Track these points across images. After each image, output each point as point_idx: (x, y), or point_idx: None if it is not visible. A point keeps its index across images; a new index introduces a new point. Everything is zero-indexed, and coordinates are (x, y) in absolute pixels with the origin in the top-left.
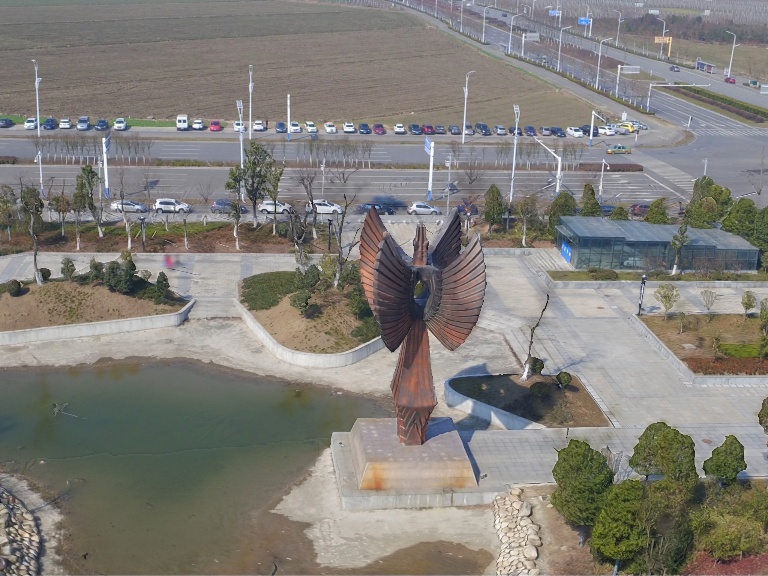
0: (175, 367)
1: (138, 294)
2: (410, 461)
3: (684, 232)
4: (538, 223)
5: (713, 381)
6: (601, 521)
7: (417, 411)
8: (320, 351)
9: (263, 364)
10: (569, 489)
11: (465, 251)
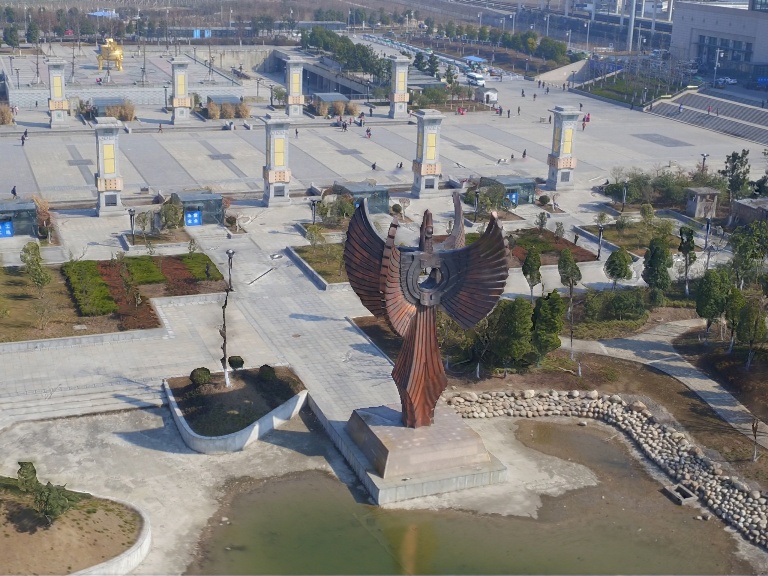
0: None
1: None
2: None
3: None
4: None
5: None
6: None
7: None
8: (133, 524)
9: None
10: None
11: None
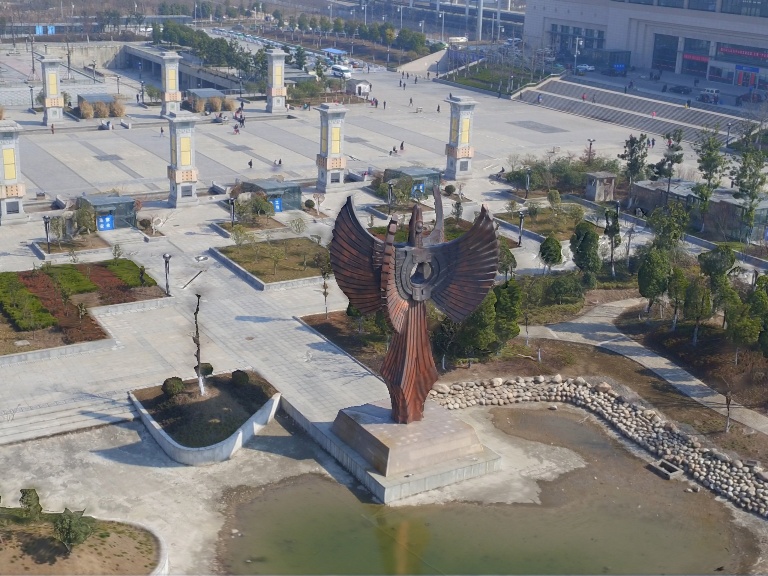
0: None
1: None
2: None
3: None
4: None
5: None
6: None
7: None
8: (148, 545)
9: None
10: None
11: None
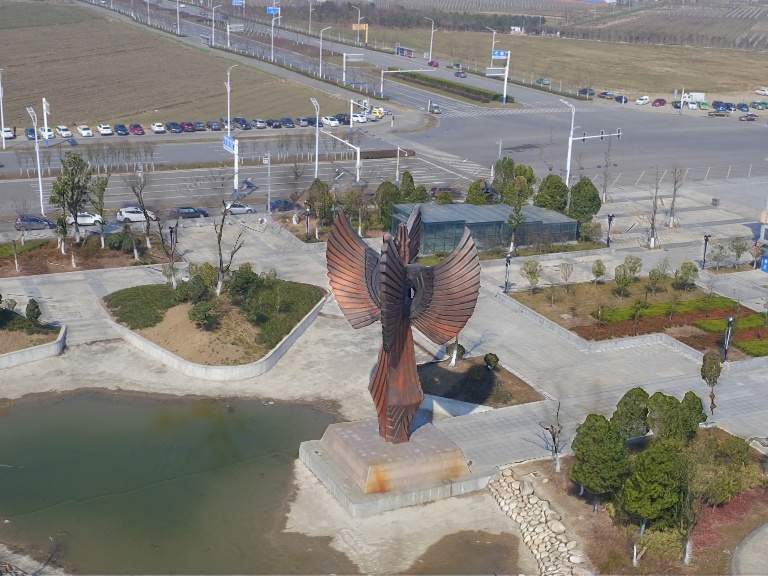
0: (83, 399)
1: (8, 326)
2: (408, 459)
3: (519, 211)
4: (365, 213)
5: (605, 346)
6: (631, 486)
7: (406, 409)
8: (233, 363)
9: (176, 384)
10: (593, 461)
11: (458, 246)
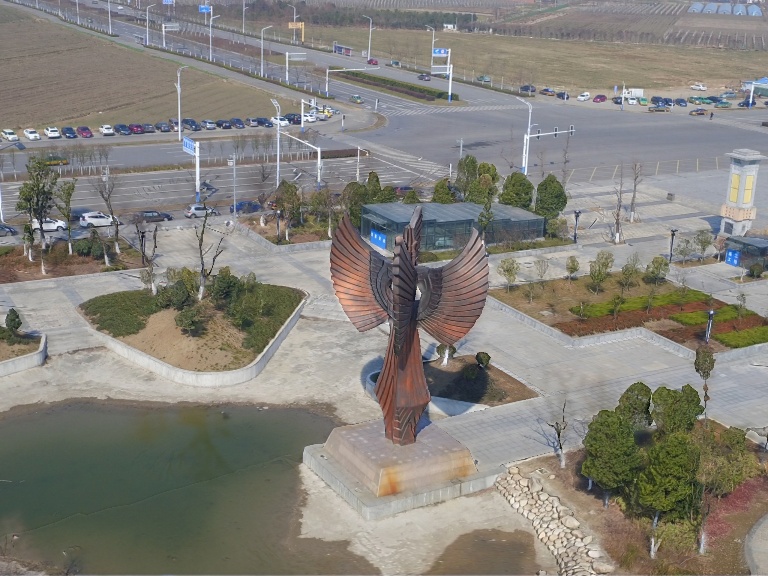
0: (74, 410)
1: None
2: (418, 460)
3: (489, 209)
4: (332, 214)
5: (588, 341)
6: (645, 480)
7: (413, 410)
8: (223, 368)
9: (166, 391)
10: (605, 456)
11: (467, 247)
